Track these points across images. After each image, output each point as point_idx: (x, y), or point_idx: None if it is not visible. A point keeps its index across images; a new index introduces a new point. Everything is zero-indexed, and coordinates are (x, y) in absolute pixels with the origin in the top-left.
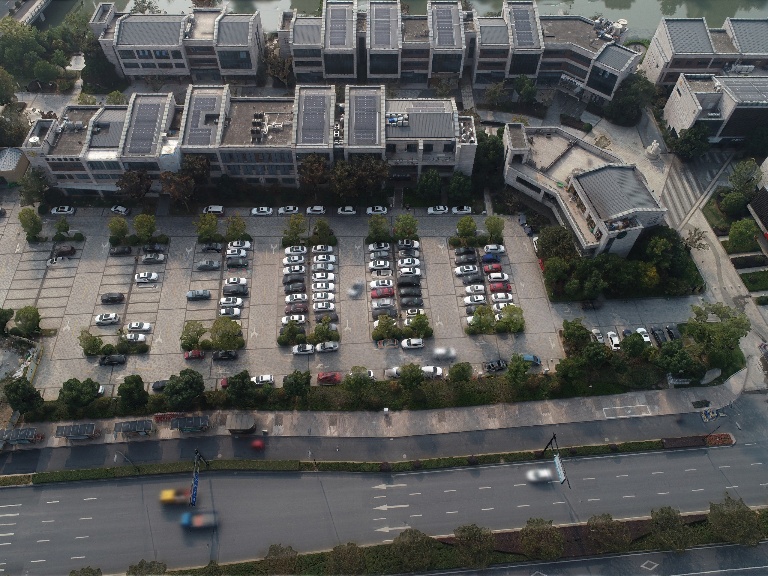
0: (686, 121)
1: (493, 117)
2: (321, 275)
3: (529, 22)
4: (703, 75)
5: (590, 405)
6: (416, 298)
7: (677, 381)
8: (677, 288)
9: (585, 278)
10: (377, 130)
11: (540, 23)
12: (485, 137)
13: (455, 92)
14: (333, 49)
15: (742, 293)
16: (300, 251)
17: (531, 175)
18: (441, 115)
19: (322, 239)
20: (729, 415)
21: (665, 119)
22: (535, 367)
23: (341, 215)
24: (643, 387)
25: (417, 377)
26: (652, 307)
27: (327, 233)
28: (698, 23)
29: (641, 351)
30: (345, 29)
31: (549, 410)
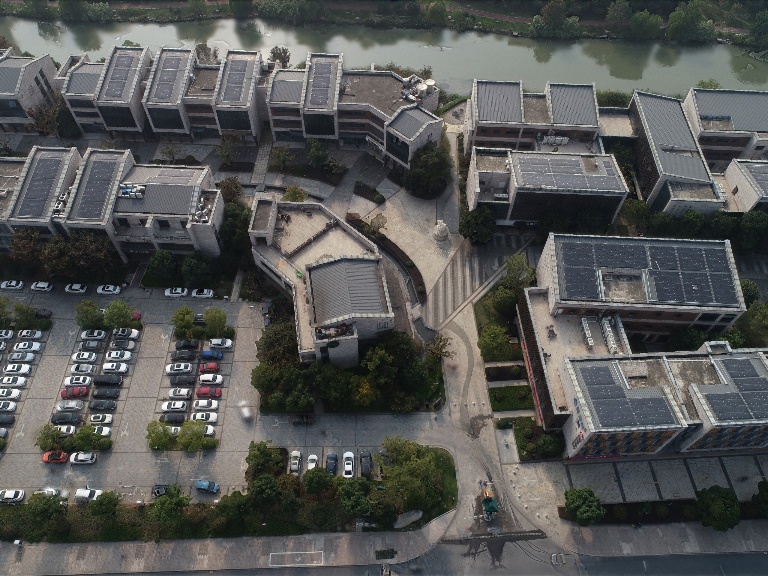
0: (472, 201)
1: (282, 182)
2: (12, 367)
3: (329, 78)
4: (498, 149)
5: (257, 548)
6: (108, 401)
7: (364, 524)
8: (403, 405)
9: (291, 391)
10: (105, 202)
11: (345, 79)
12: (238, 212)
13: (251, 150)
14: (106, 102)
15: (484, 412)
16: (3, 336)
17: (273, 260)
18: (182, 187)
19: (33, 322)
20: (413, 571)
21: (466, 193)
22: (211, 495)
23: (69, 293)
24: (323, 529)
25: (43, 510)
26: (374, 425)
27: (30, 318)
28: (514, 86)
29: (322, 488)
30: (126, 79)
31: (207, 552)
